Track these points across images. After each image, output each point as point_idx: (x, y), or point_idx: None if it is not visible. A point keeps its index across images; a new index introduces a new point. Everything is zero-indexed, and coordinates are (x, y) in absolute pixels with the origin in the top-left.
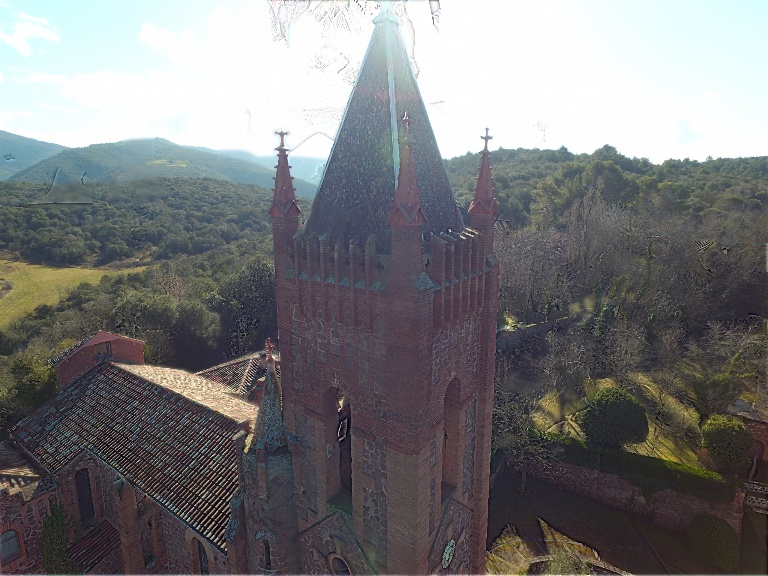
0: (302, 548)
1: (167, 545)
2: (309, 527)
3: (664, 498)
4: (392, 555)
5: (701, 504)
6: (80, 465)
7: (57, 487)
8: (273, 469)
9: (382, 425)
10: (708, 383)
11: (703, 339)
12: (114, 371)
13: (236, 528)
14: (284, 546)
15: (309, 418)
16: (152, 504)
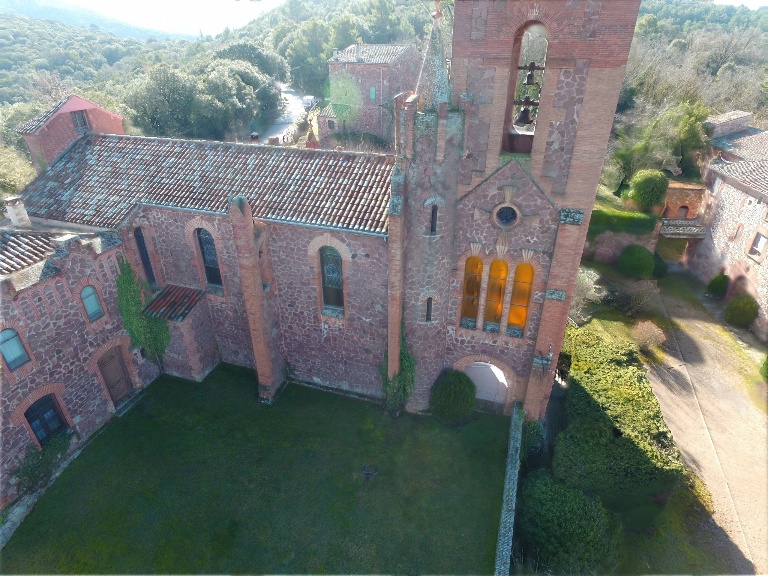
0: (459, 215)
1: (276, 272)
2: (472, 189)
3: (603, 239)
4: (574, 178)
5: (630, 238)
6: (136, 222)
7: (121, 243)
8: (450, 128)
9: (589, 45)
10: (633, 148)
11: (630, 113)
12: (112, 140)
13: (401, 202)
14: (449, 211)
15: (488, 69)
16: (263, 227)
